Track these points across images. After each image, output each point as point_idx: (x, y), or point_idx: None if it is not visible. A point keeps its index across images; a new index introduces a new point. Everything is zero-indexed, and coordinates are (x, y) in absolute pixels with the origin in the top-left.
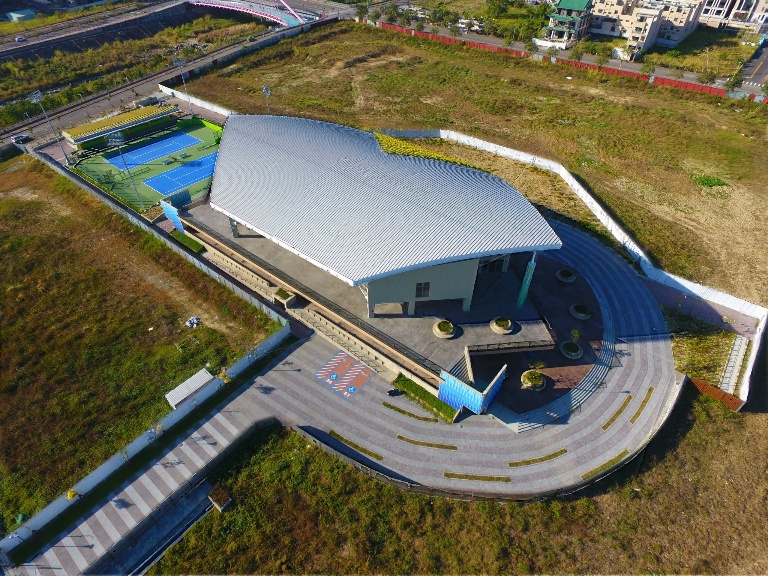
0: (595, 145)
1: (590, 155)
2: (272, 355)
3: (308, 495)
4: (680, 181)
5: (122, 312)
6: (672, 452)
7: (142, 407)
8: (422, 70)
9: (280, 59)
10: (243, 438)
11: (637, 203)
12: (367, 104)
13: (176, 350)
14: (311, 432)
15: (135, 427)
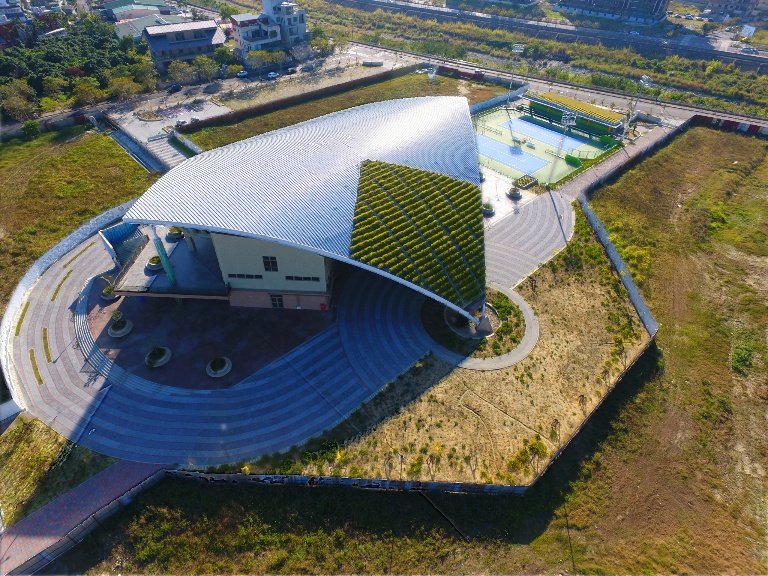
0: None
1: None
2: None
3: None
4: None
5: None
6: None
7: None
8: None
9: None
10: None
11: None
12: (764, 269)
13: None
14: None
15: None
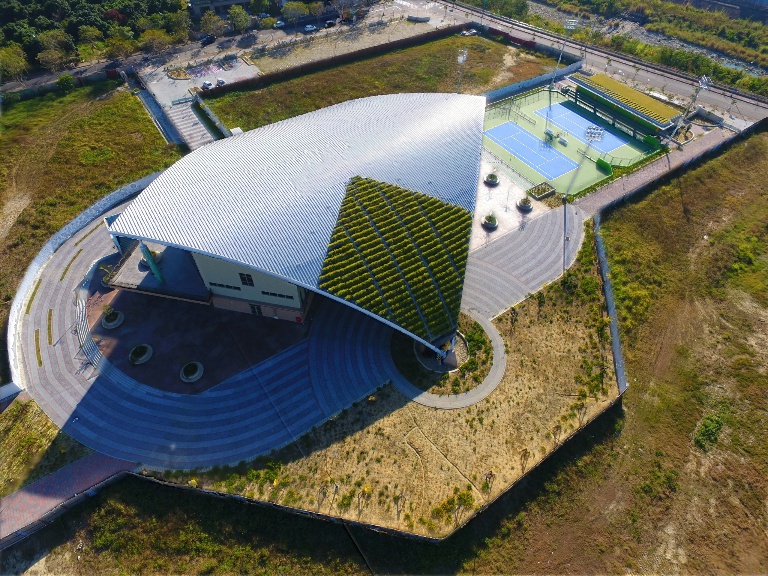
0: None
1: None
2: None
3: None
4: None
5: None
6: None
7: (247, 127)
8: None
9: None
10: None
11: None
12: None
13: None
14: None
15: (235, 125)
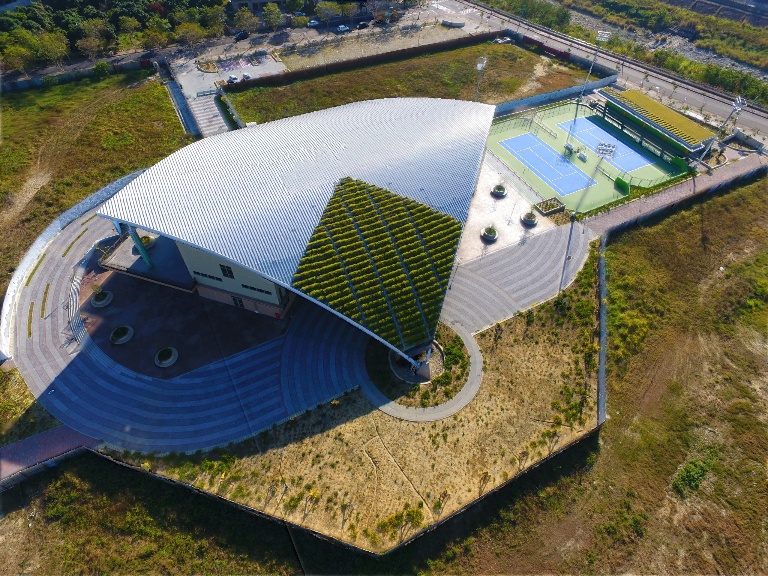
0: None
1: None
2: None
3: None
4: None
5: None
6: None
7: None
8: None
9: None
10: None
11: None
12: None
13: None
14: None
15: (253, 120)
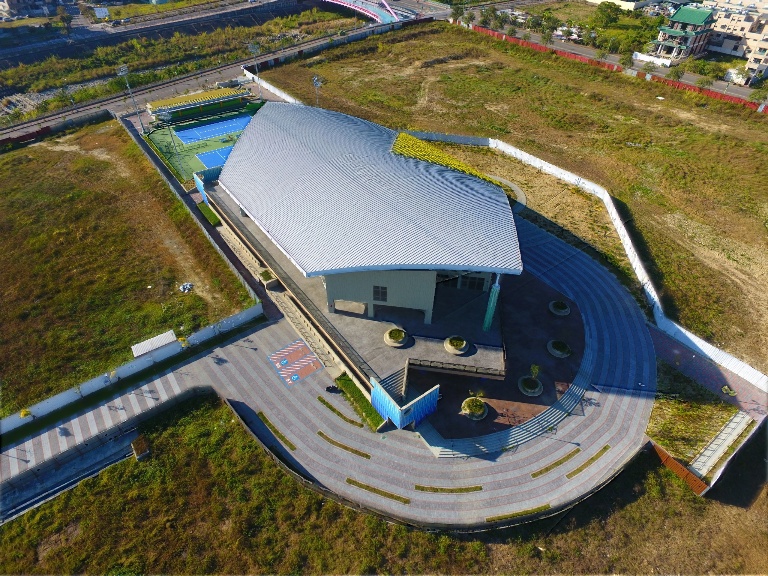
0: (660, 174)
1: (649, 184)
2: (238, 330)
3: (214, 465)
4: (748, 226)
5: (133, 268)
6: (600, 520)
7: (114, 353)
8: (500, 76)
9: (363, 54)
10: (179, 399)
11: (682, 244)
12: (428, 105)
13: (161, 309)
14: (242, 409)
15: (101, 369)
